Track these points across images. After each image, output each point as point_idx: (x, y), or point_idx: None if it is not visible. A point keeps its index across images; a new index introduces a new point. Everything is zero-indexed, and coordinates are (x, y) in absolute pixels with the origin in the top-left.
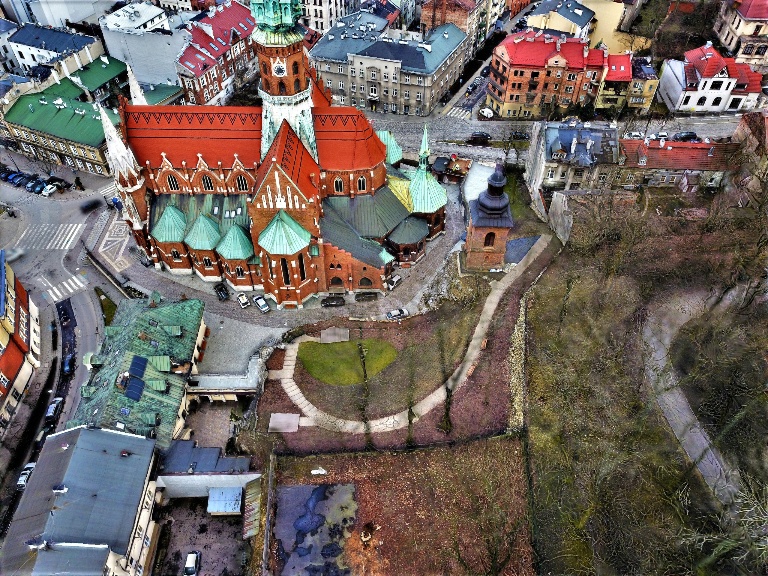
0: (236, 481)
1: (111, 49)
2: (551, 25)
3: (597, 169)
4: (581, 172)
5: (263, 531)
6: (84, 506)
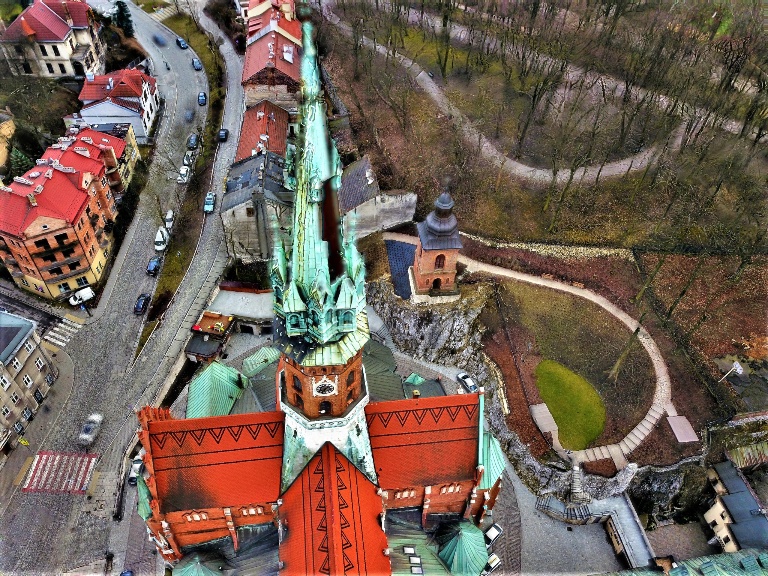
0: None
1: None
2: None
3: None
4: None
5: None
6: None
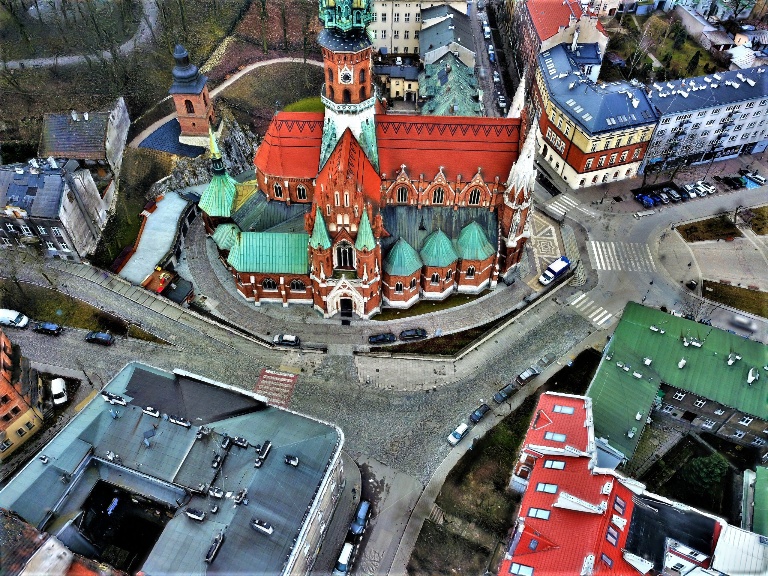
0: None
1: None
2: None
3: None
4: None
5: None
6: (440, 30)
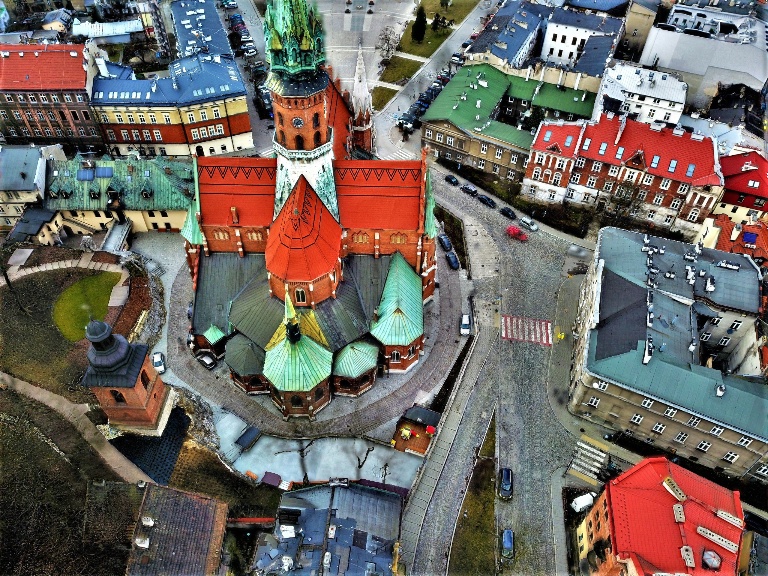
0: None
1: None
2: None
3: None
4: None
5: None
6: None
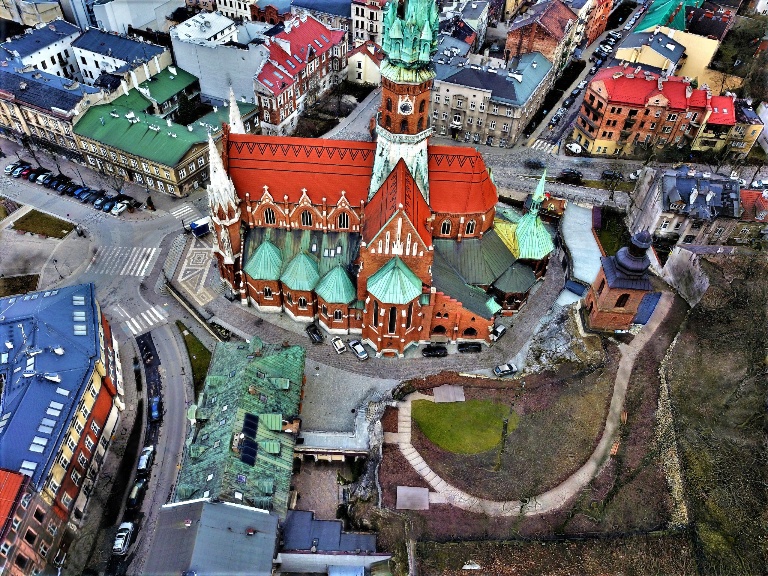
0: (360, 561)
1: (180, 60)
2: (642, 59)
3: (716, 222)
4: (699, 225)
5: None
6: None
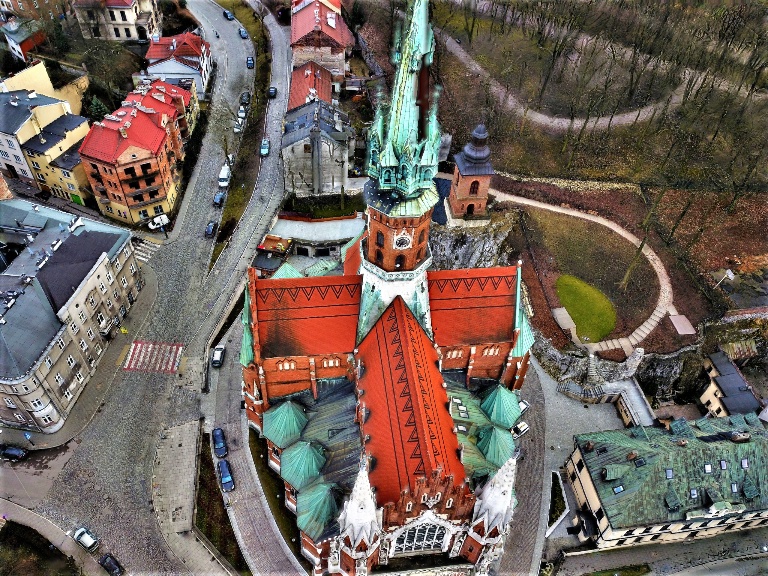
0: None
1: None
2: (42, 123)
3: None
4: None
5: (763, 324)
6: None
